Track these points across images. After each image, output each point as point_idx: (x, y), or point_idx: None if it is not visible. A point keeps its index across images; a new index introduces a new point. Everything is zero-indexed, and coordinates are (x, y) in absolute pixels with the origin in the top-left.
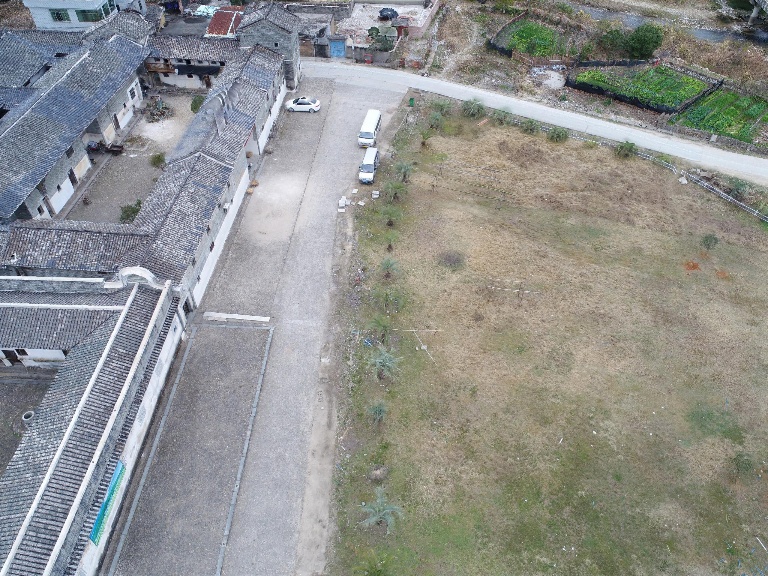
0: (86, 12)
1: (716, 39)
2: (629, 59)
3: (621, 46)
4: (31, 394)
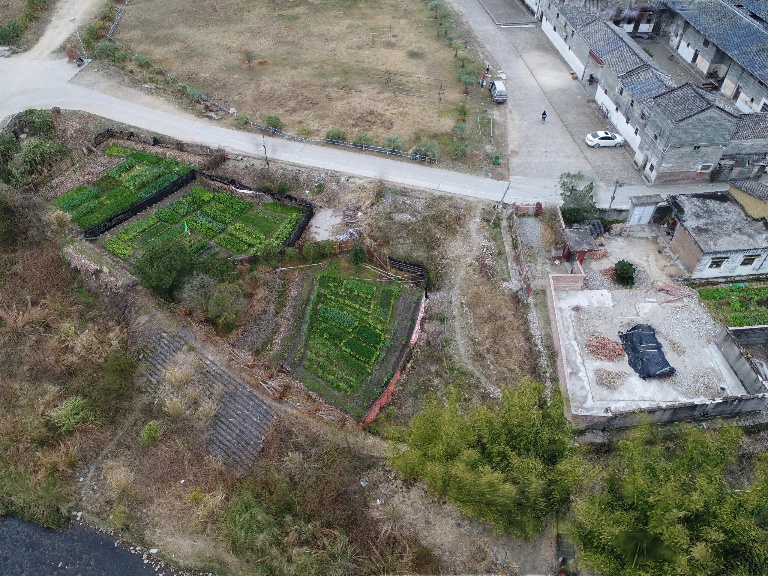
0: None
1: None
2: None
3: None
4: None
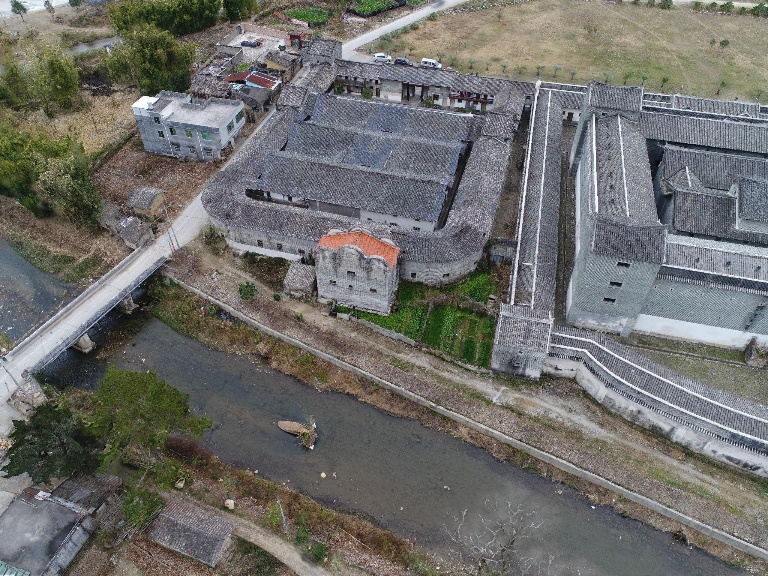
0: (238, 114)
1: None
2: None
3: None
4: (566, 134)
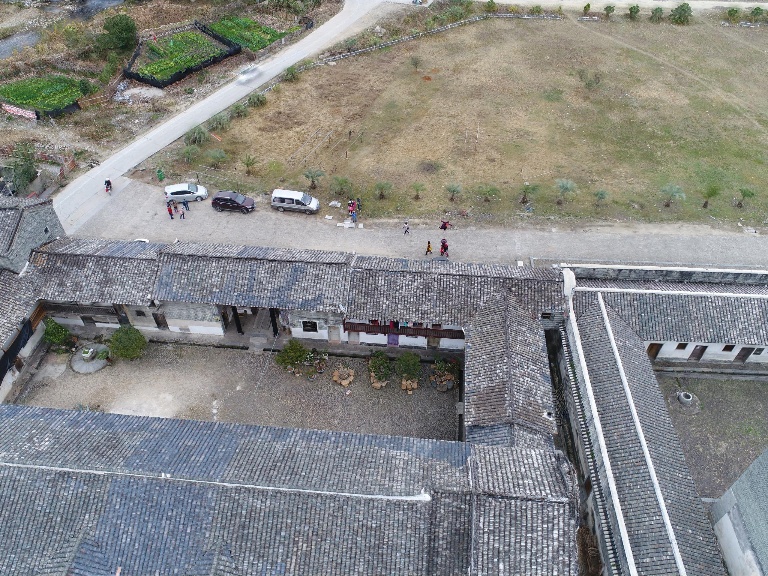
0: None
1: (80, 20)
2: (129, 51)
3: (120, 43)
4: None
